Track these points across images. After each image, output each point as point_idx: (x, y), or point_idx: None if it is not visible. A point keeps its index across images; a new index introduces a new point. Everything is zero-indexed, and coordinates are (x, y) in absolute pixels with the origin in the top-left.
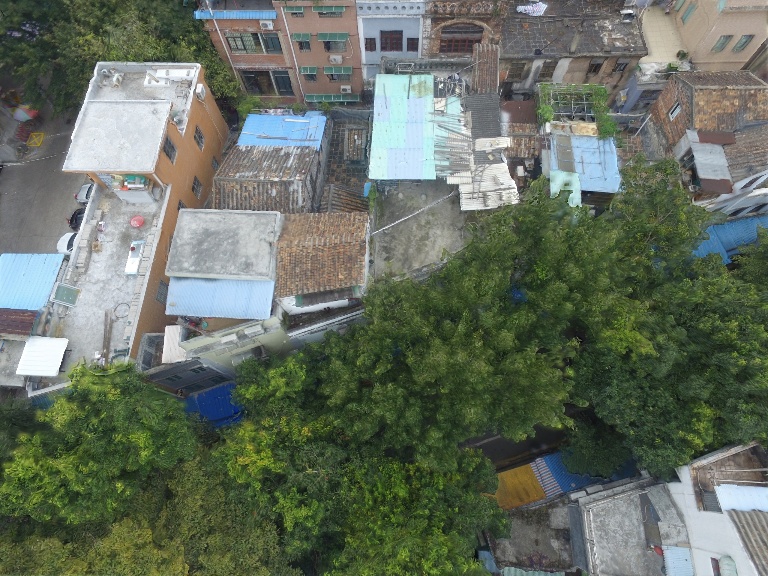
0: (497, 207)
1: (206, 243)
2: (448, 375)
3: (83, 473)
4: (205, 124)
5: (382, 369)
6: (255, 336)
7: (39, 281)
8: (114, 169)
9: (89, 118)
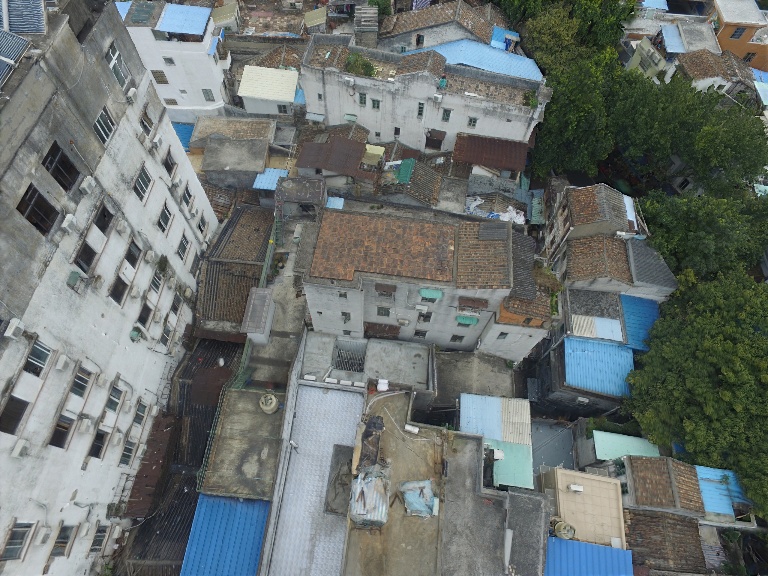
0: None
1: (697, 32)
2: (664, 95)
3: (598, 8)
4: (760, 61)
5: None
6: (653, 62)
7: (655, 4)
8: (722, 10)
9: (746, 1)
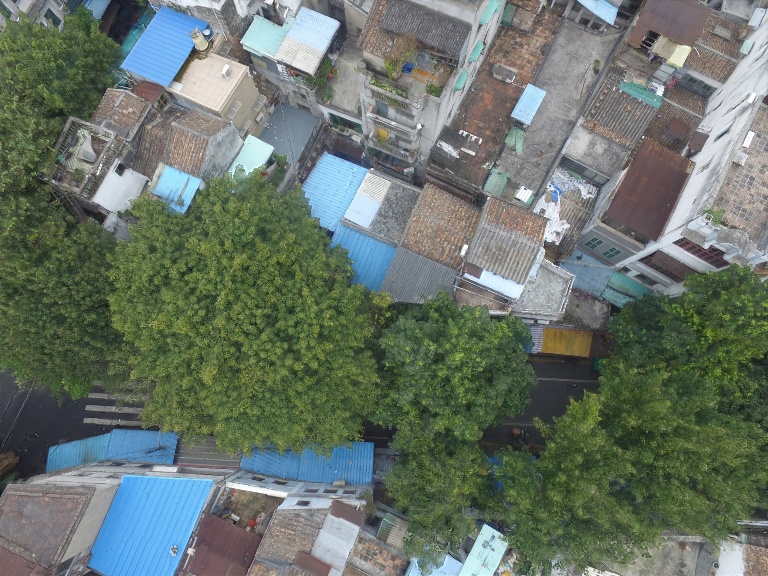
0: (606, 572)
1: None
2: None
3: None
4: None
5: (740, 462)
6: None
7: None
8: None
9: None
